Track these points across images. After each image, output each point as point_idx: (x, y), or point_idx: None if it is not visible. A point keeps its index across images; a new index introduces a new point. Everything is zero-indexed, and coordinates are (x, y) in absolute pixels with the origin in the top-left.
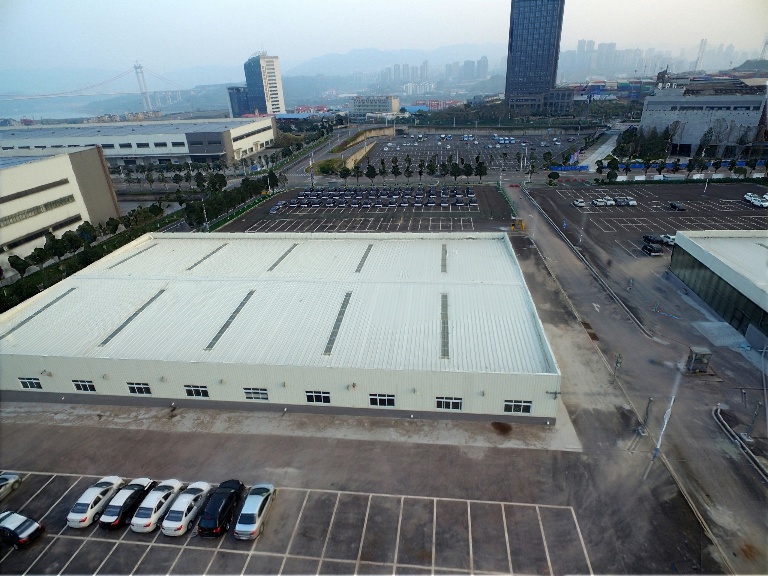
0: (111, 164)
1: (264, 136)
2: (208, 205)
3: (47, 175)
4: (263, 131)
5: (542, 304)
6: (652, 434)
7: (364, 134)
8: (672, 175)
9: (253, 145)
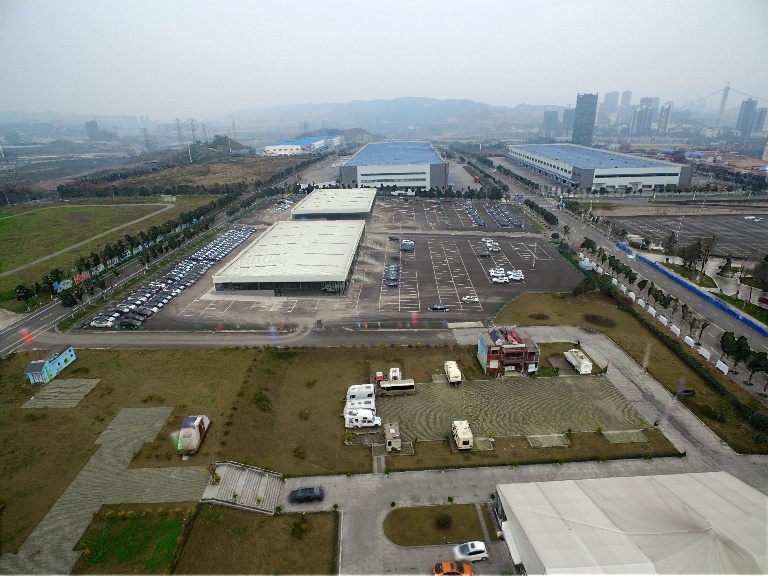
0: None
1: (658, 180)
2: (430, 192)
3: (418, 170)
4: (657, 176)
5: None
6: None
7: None
8: None
9: (630, 184)
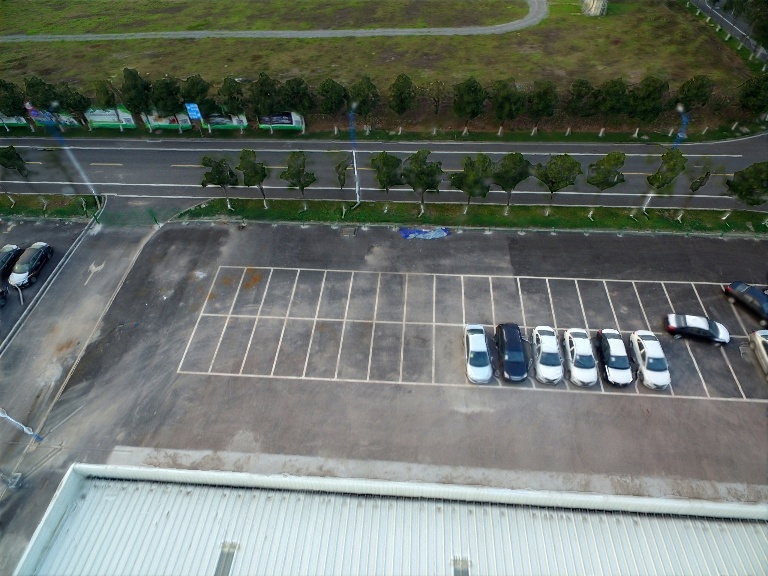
0: None
1: None
2: None
3: None
4: None
5: None
6: (2, 488)
7: None
8: None
9: None
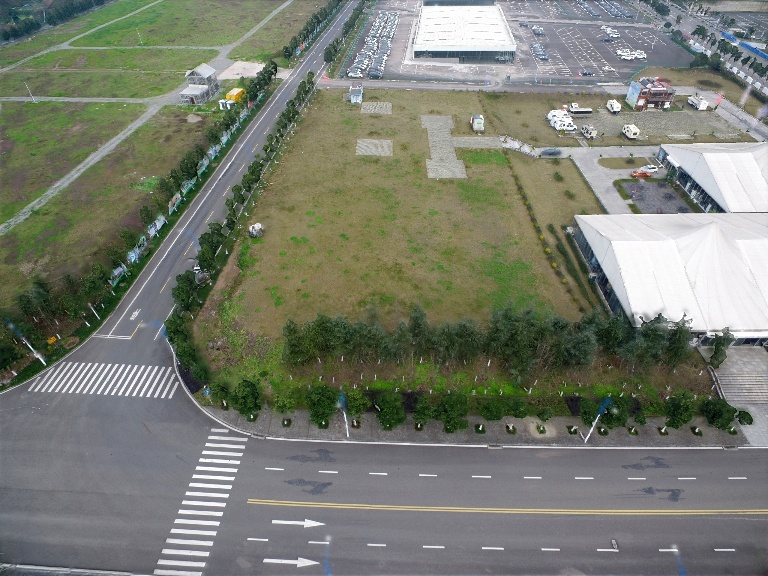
0: None
1: None
2: None
3: None
4: None
5: None
6: None
7: None
8: (697, 46)
9: None
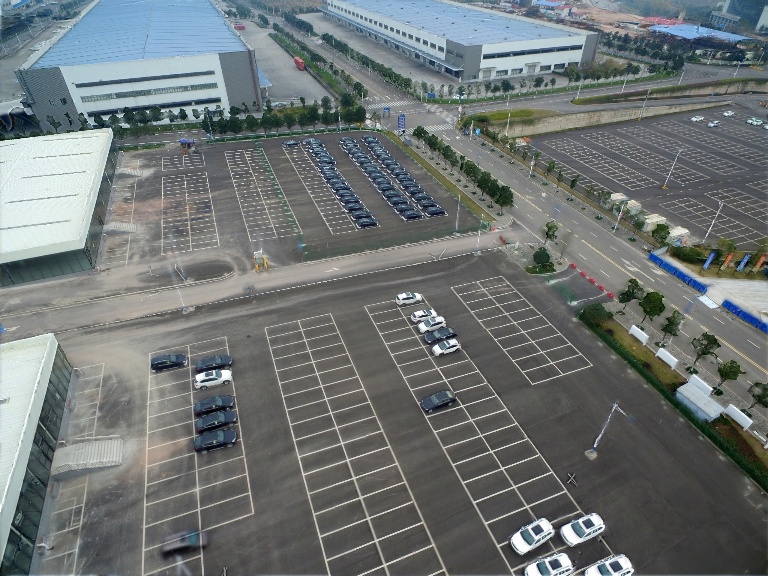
0: (409, 54)
1: (558, 57)
2: (232, 121)
3: (197, 66)
4: (558, 51)
5: (19, 299)
6: None
7: (735, 85)
8: (697, 395)
9: (525, 66)
